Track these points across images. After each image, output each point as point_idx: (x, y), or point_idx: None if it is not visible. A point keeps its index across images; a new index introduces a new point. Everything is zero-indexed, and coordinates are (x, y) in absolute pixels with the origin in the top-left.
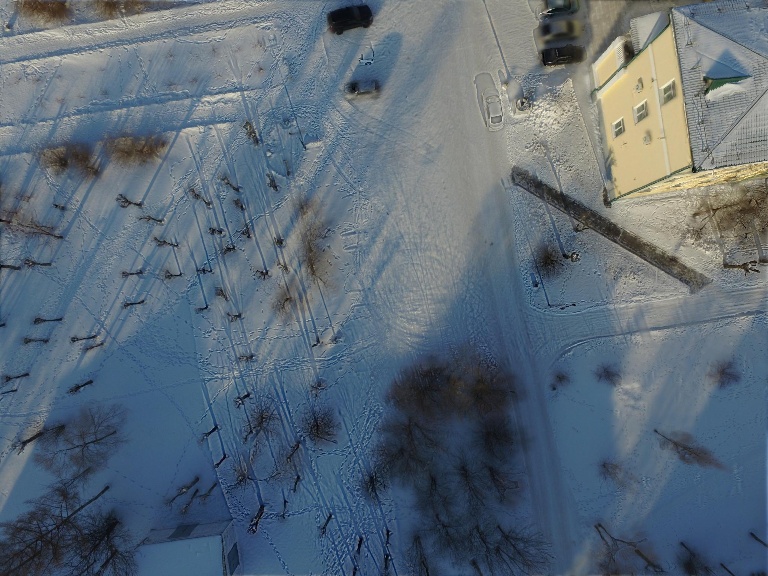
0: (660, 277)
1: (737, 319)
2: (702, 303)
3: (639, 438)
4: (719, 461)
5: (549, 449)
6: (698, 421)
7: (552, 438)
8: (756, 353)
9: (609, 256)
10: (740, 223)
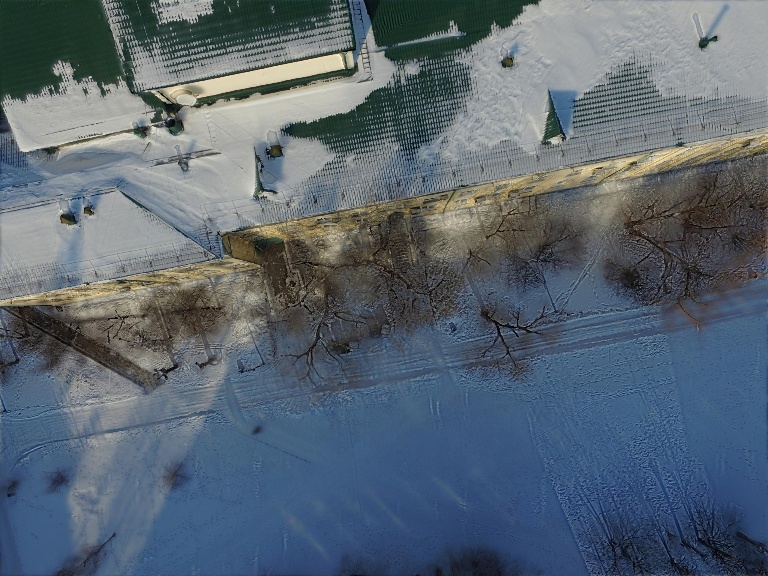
0: (113, 379)
1: (189, 419)
2: (156, 404)
3: (99, 542)
4: (177, 563)
5: (12, 555)
6: (155, 523)
7: (14, 544)
8: (209, 453)
9: (61, 360)
10: (184, 324)
